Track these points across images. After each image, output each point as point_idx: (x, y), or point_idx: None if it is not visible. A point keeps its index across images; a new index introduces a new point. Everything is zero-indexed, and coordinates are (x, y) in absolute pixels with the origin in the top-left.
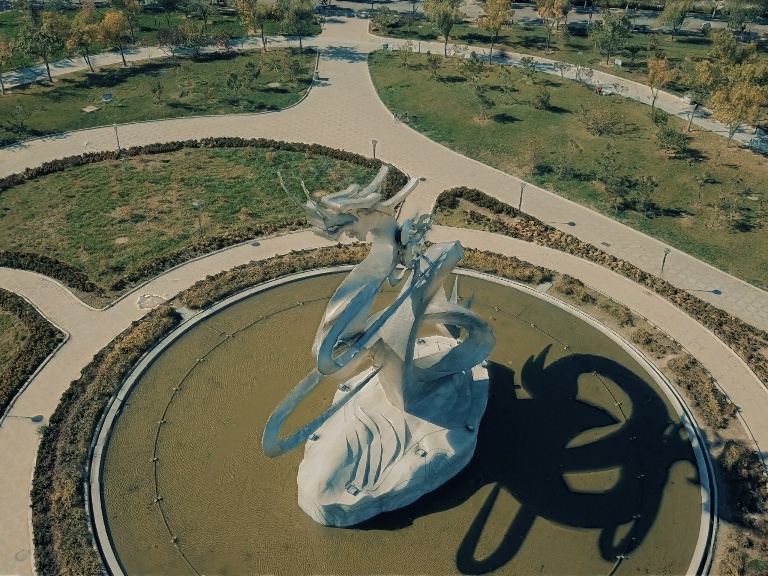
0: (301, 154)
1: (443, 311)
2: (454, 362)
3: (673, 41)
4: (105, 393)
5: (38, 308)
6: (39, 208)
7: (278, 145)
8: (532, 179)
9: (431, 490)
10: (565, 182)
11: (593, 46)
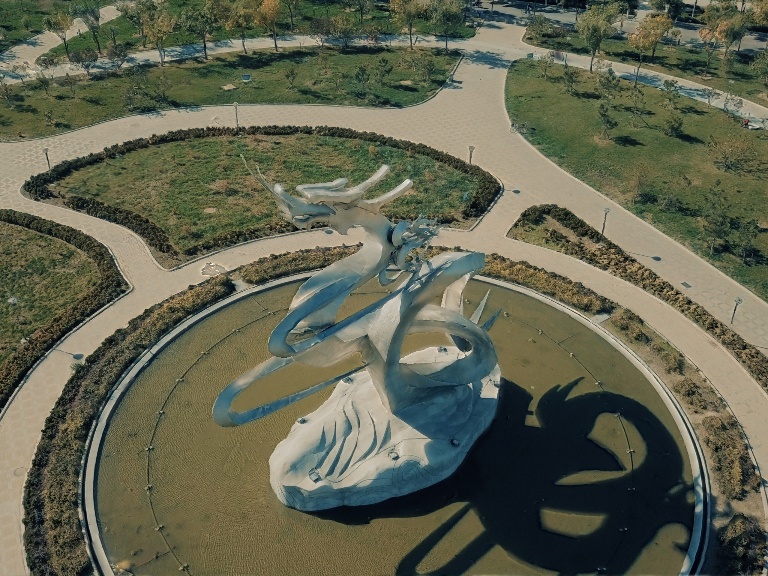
0: (404, 152)
1: (443, 320)
2: (455, 374)
3: None
4: (141, 345)
5: (117, 260)
6: (151, 171)
7: (385, 140)
8: (632, 206)
9: (400, 495)
10: (667, 214)
11: (759, 76)
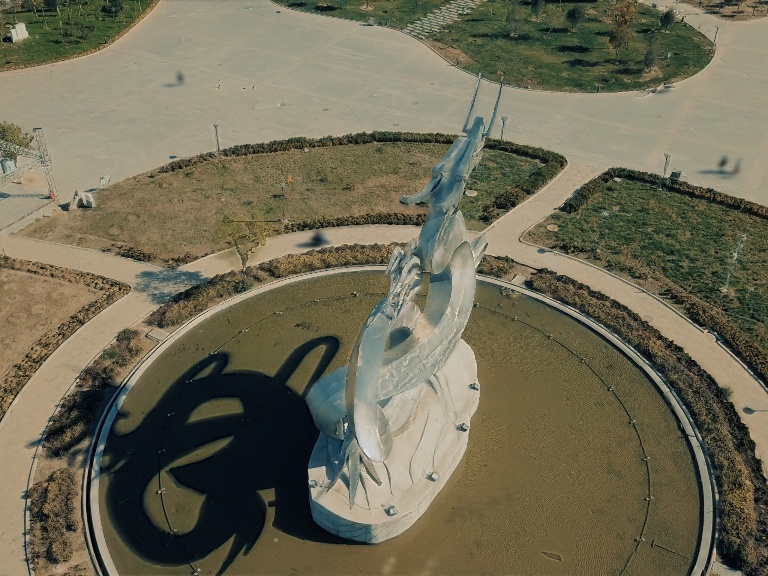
0: None
1: None
2: None
3: None
4: None
5: None
6: None
7: None
8: None
9: None
10: None
11: None
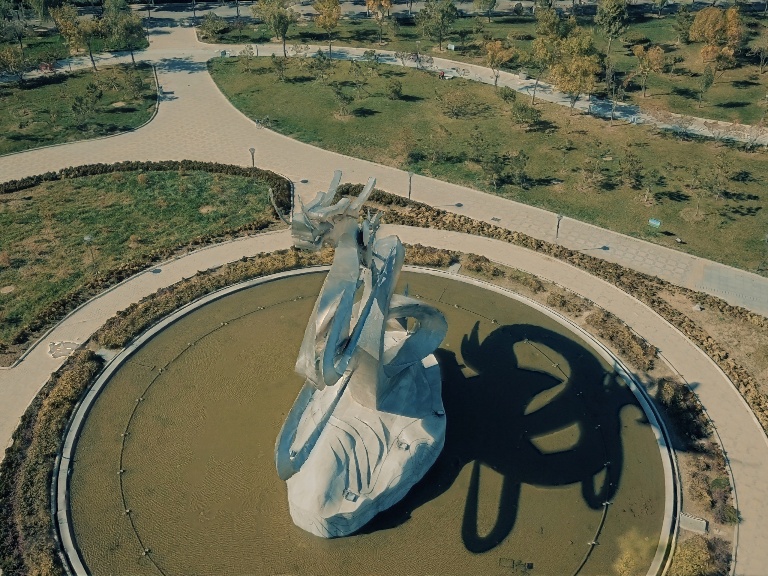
0: (173, 172)
1: (399, 305)
2: (410, 353)
3: (491, 22)
4: (48, 454)
5: None
6: None
7: (146, 166)
8: (409, 167)
9: (418, 481)
10: (440, 166)
11: (421, 34)
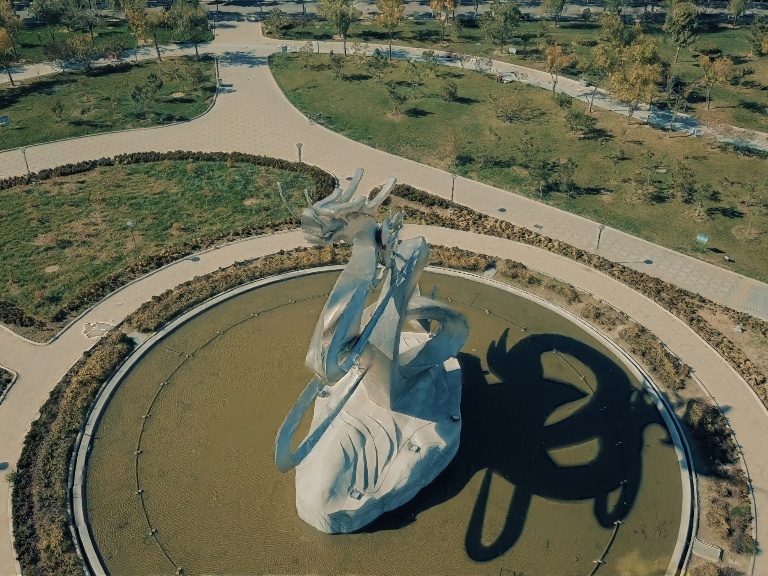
0: (222, 163)
1: (419, 307)
2: (430, 356)
3: (557, 27)
4: (71, 430)
5: None
6: None
7: (197, 156)
8: (456, 170)
9: (427, 484)
10: (487, 170)
11: (485, 36)
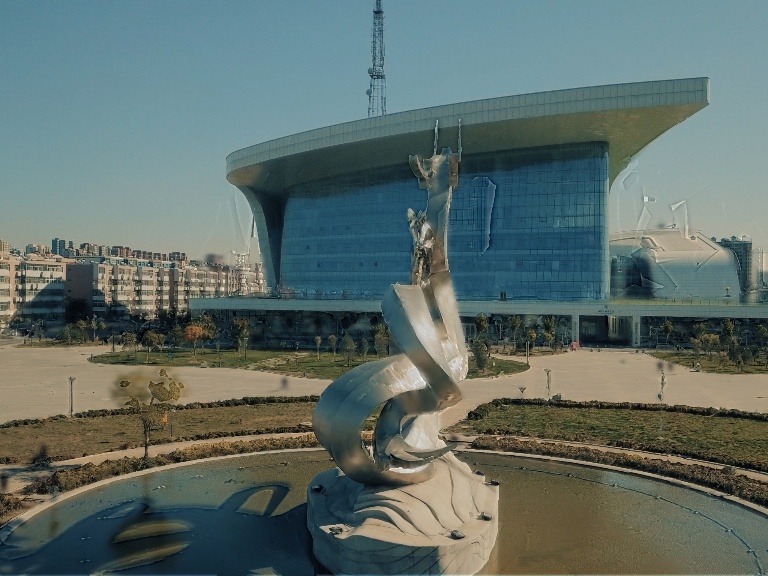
0: None
1: None
2: None
3: None
4: None
5: None
6: None
7: None
8: None
9: None
10: None
11: None
